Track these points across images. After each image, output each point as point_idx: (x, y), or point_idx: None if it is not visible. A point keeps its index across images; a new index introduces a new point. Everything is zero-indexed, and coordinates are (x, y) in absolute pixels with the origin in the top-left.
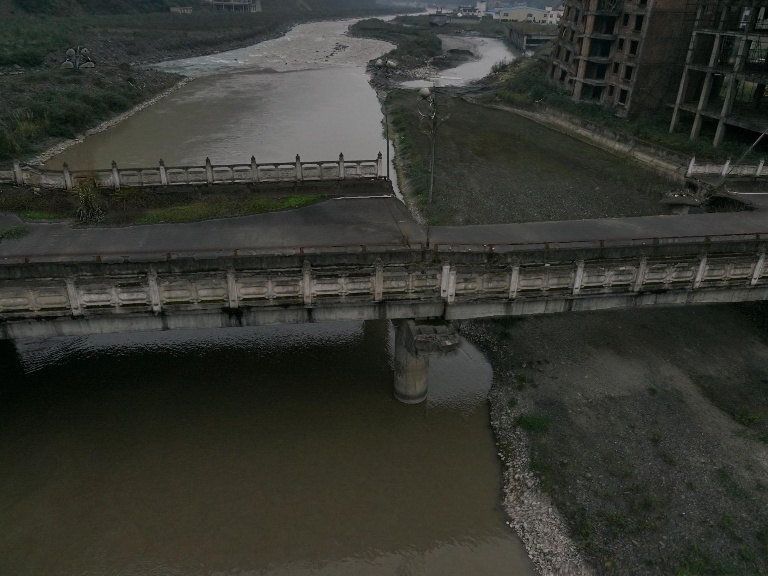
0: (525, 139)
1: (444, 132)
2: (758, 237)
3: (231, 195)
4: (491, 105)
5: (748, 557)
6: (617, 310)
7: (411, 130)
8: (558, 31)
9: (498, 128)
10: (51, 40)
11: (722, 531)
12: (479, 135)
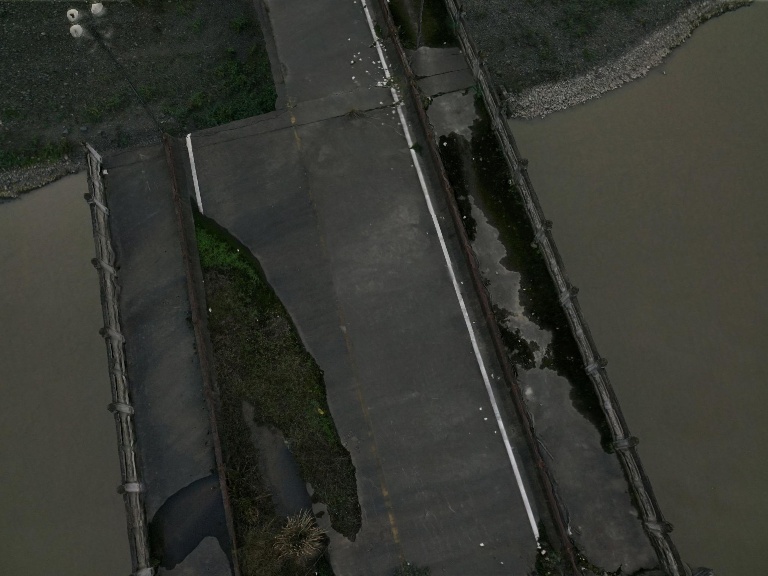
0: None
1: None
2: None
3: (209, 347)
4: None
5: (556, 1)
6: None
7: None
8: None
9: None
10: None
11: (538, 7)
12: None
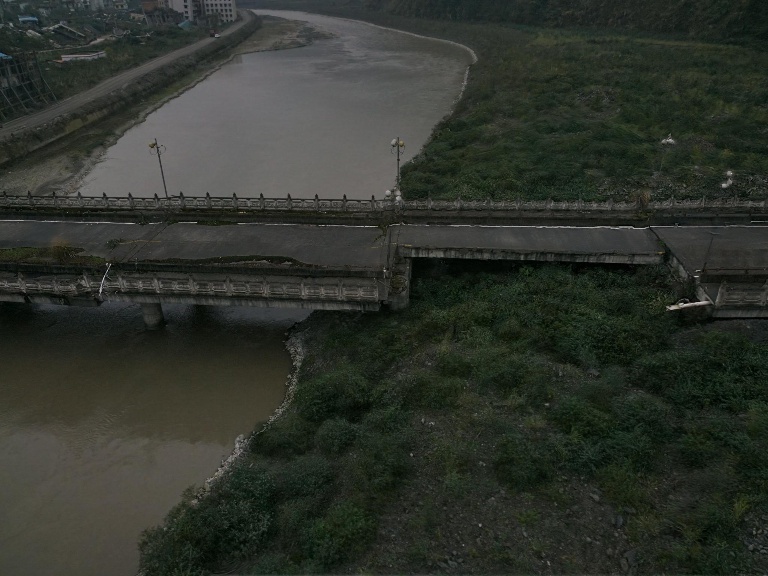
0: None
1: None
2: None
3: None
4: None
5: None
6: None
7: None
8: None
9: None
10: None
11: None
12: None
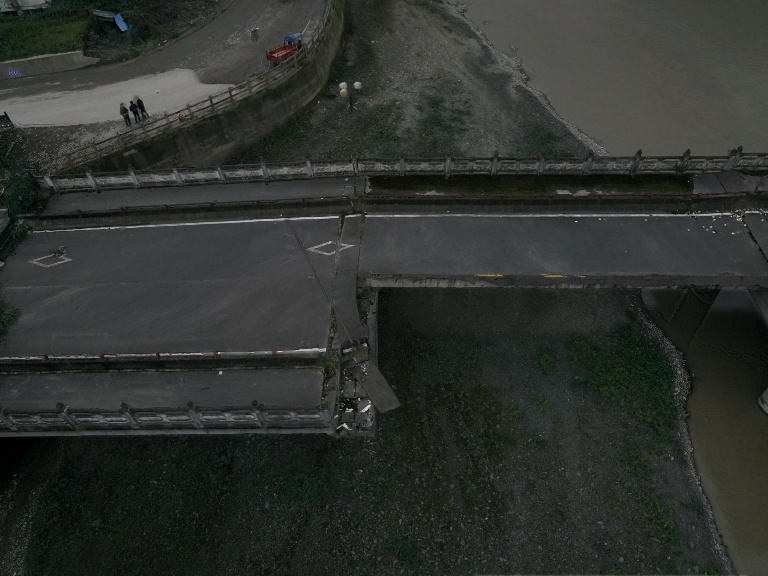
0: None
1: None
2: (454, 196)
3: None
4: None
5: None
6: (509, 334)
7: None
8: None
9: None
10: None
11: None
12: None
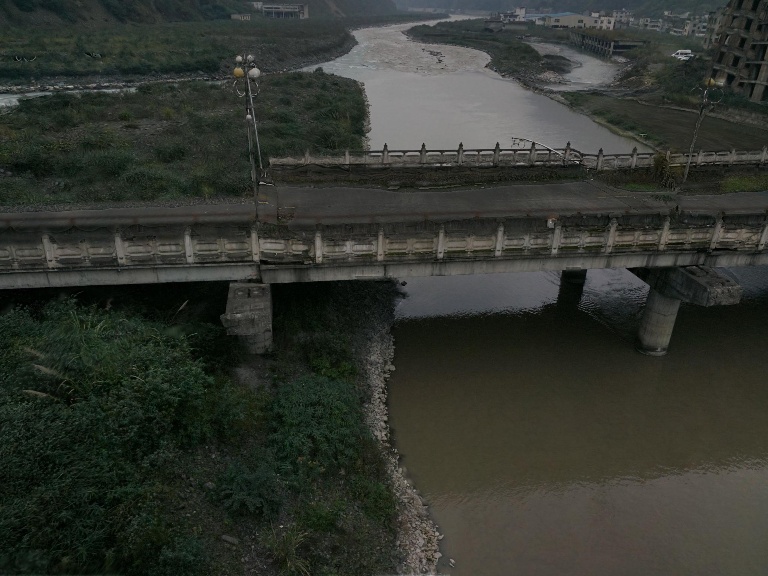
0: (757, 136)
1: (678, 130)
2: None
3: (745, 173)
4: (667, 106)
5: None
6: None
7: (644, 128)
8: (718, 38)
9: (717, 126)
10: (211, 48)
11: None
12: (713, 132)
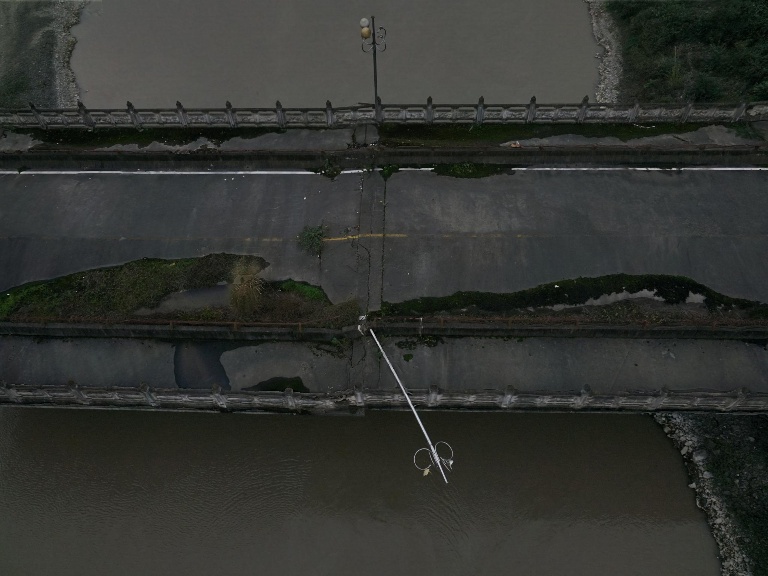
0: None
1: None
2: None
3: None
4: None
5: None
6: None
7: None
8: None
9: None
10: None
11: None
12: None
